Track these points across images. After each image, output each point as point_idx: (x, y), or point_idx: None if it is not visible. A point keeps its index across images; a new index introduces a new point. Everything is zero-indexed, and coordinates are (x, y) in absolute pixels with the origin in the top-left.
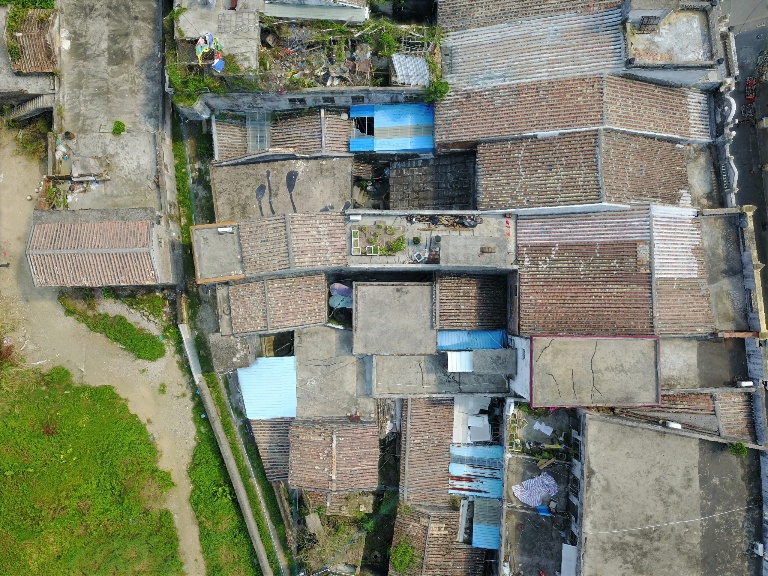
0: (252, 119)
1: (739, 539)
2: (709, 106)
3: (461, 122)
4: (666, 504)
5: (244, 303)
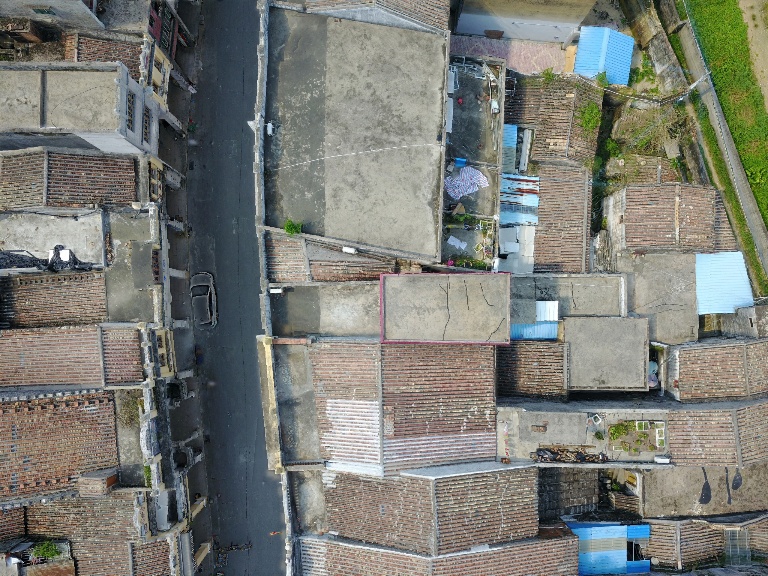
0: (745, 558)
1: (287, 138)
2: (300, 574)
3: (555, 559)
4: (358, 173)
5: (766, 372)
